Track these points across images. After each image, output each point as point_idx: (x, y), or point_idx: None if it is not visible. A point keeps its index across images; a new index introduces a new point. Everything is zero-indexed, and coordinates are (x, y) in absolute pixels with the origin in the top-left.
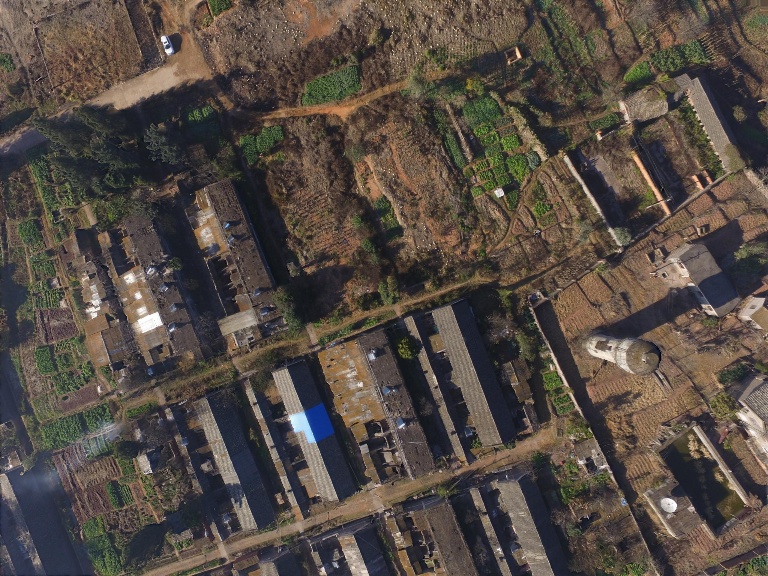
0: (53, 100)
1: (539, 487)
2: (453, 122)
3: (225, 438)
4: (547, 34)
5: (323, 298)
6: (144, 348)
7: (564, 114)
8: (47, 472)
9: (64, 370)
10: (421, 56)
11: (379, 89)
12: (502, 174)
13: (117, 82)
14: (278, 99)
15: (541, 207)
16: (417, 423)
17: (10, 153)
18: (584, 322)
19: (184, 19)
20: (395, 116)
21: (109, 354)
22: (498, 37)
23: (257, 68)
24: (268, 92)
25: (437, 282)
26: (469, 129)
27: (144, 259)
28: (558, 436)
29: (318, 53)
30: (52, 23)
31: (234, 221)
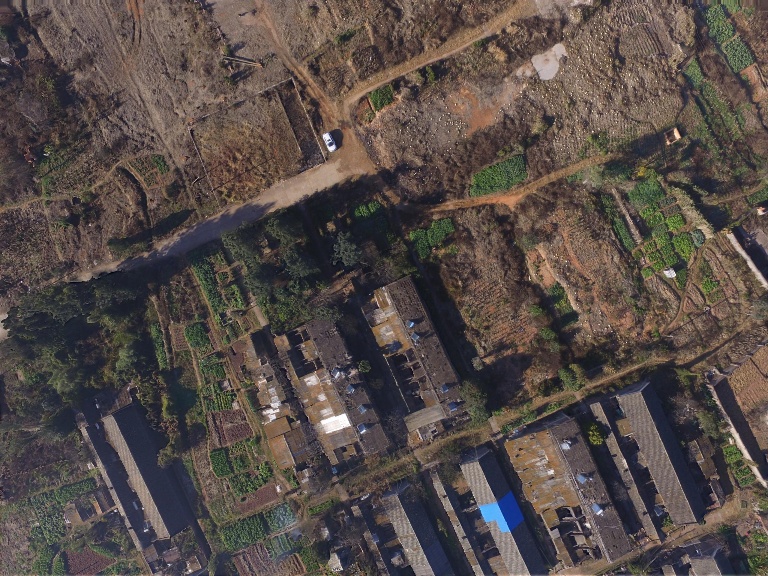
0: (212, 201)
1: (729, 559)
2: (620, 206)
3: (417, 532)
4: (701, 112)
5: (504, 387)
6: (328, 448)
7: (723, 190)
8: (228, 574)
9: (240, 472)
10: (584, 141)
11: (545, 176)
12: (669, 254)
13: (278, 180)
14: (446, 192)
15: (709, 284)
16: (612, 508)
17: (169, 256)
18: (759, 395)
19: (344, 115)
20: (565, 204)
21: (293, 456)
22: (656, 118)
23: (424, 162)
24: (436, 185)
25: (619, 366)
26: (635, 211)
27: (329, 362)
28: (742, 508)
29: (484, 144)
30: (207, 124)
31: (417, 319)
